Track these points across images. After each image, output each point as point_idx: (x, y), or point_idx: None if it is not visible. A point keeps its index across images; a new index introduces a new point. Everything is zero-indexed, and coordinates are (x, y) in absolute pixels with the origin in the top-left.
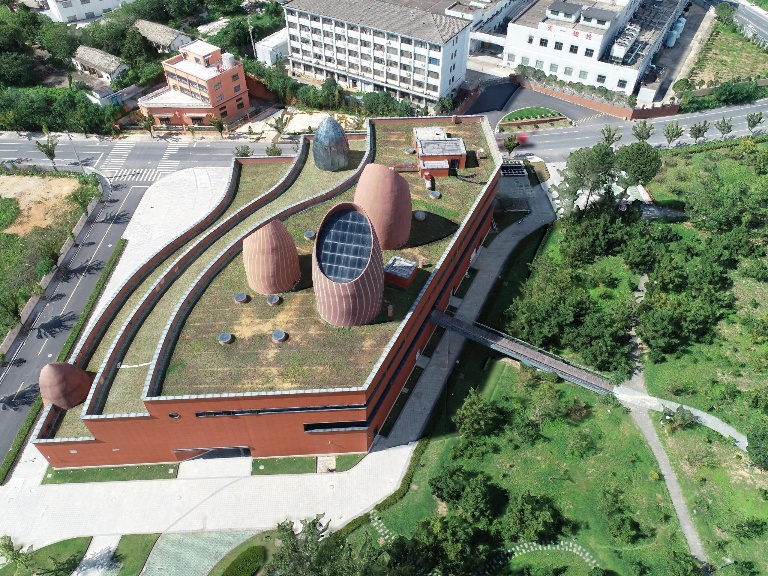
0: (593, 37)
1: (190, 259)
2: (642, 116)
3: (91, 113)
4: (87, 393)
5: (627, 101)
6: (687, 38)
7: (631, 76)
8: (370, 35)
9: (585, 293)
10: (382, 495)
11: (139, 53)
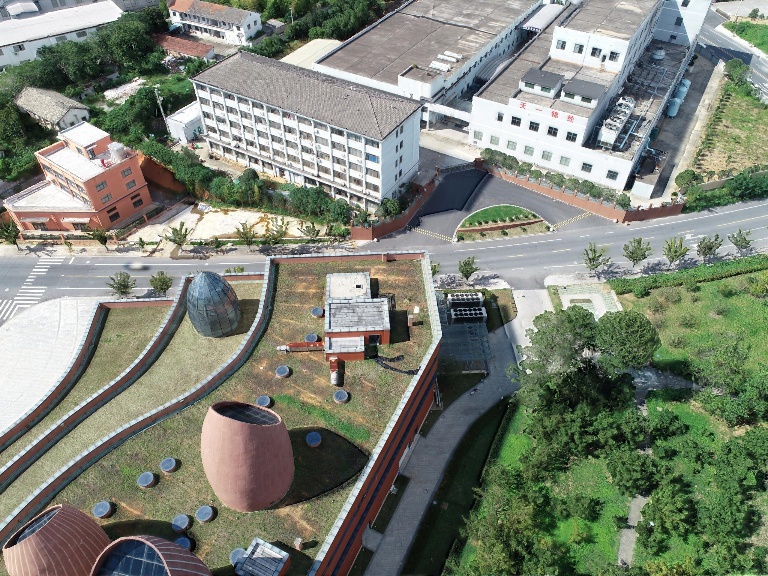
0: (576, 119)
1: None
2: (637, 218)
3: None
4: None
5: (618, 201)
6: (692, 103)
7: (623, 167)
8: (294, 121)
9: (553, 532)
10: None
11: (17, 134)
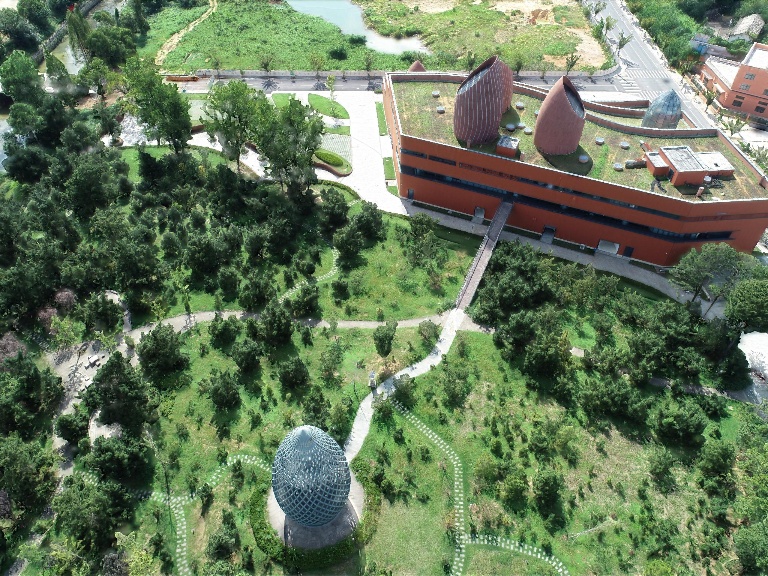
0: None
1: None
2: None
3: (679, 45)
4: None
5: None
6: None
7: None
8: None
9: None
10: None
11: None
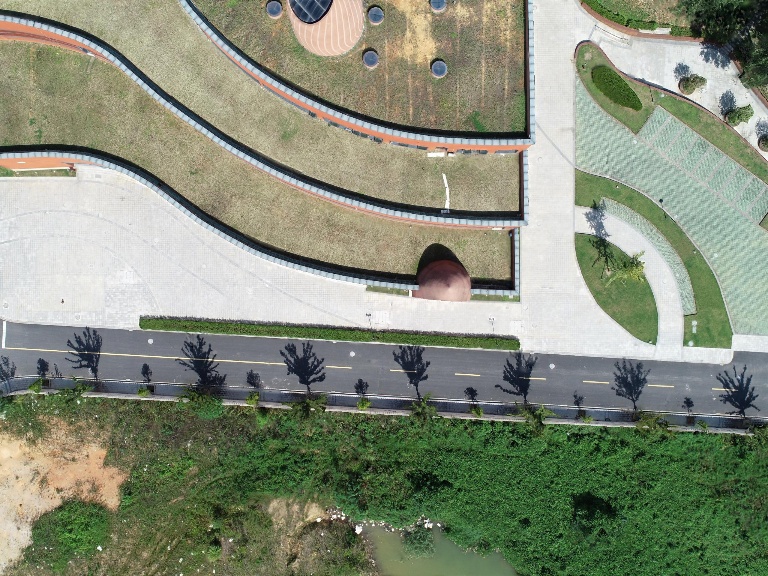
0: None
1: None
2: None
3: None
4: (450, 261)
5: None
6: None
7: None
8: None
9: None
10: None
11: None
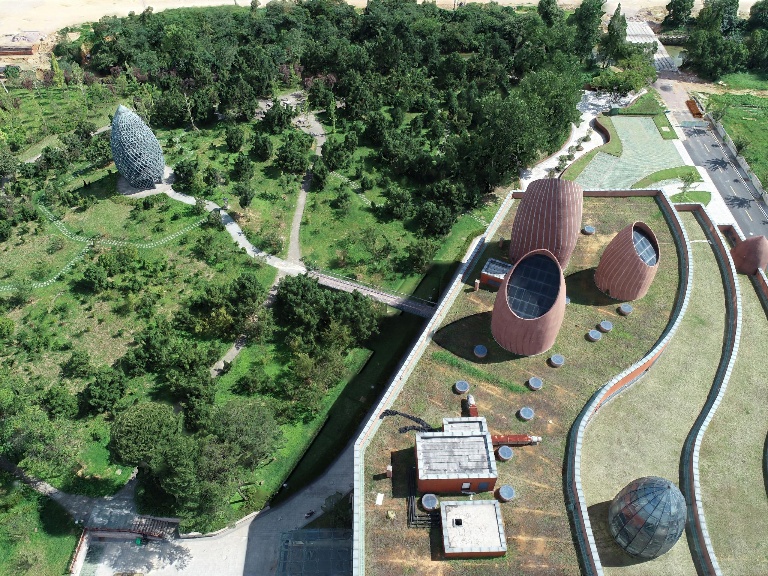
0: None
1: (731, 336)
2: None
3: None
4: None
5: None
6: None
7: None
8: None
9: None
10: None
11: None
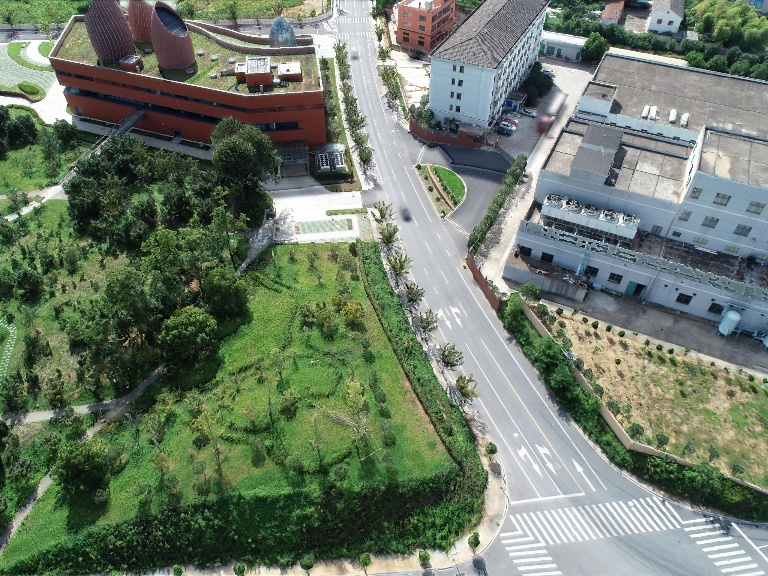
0: None
1: None
2: None
3: None
4: None
5: None
6: None
7: None
8: None
9: None
10: (46, 120)
11: None
